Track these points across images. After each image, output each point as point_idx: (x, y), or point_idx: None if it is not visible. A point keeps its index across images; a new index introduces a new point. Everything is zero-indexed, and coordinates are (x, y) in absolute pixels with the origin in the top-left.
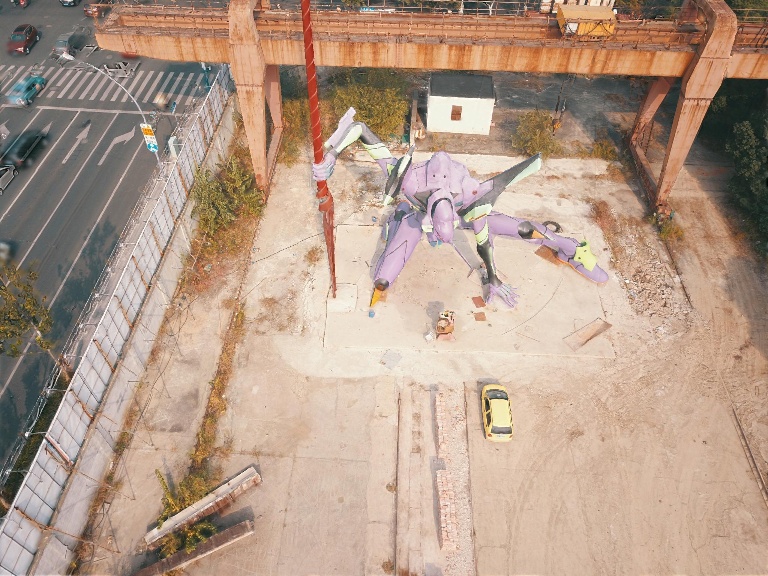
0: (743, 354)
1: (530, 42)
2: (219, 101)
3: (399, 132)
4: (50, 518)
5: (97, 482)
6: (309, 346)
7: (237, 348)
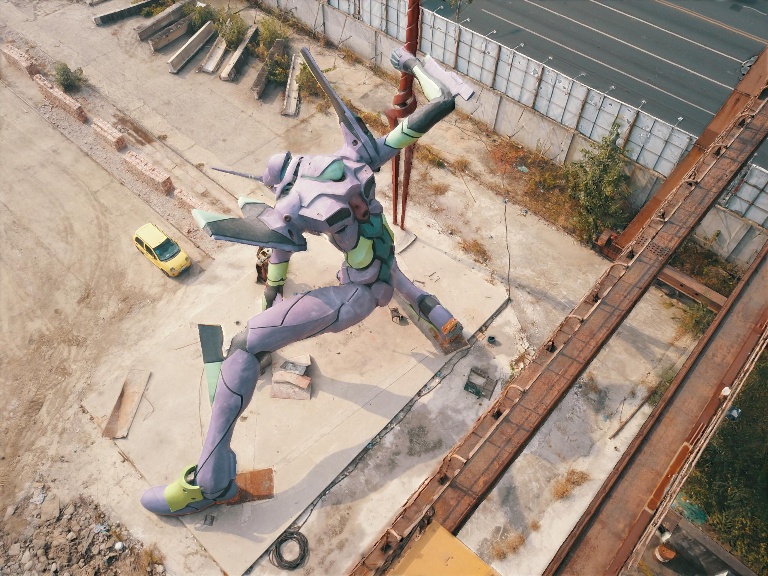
0: None
1: (479, 461)
2: None
3: None
4: (334, 6)
5: None
6: None
7: None
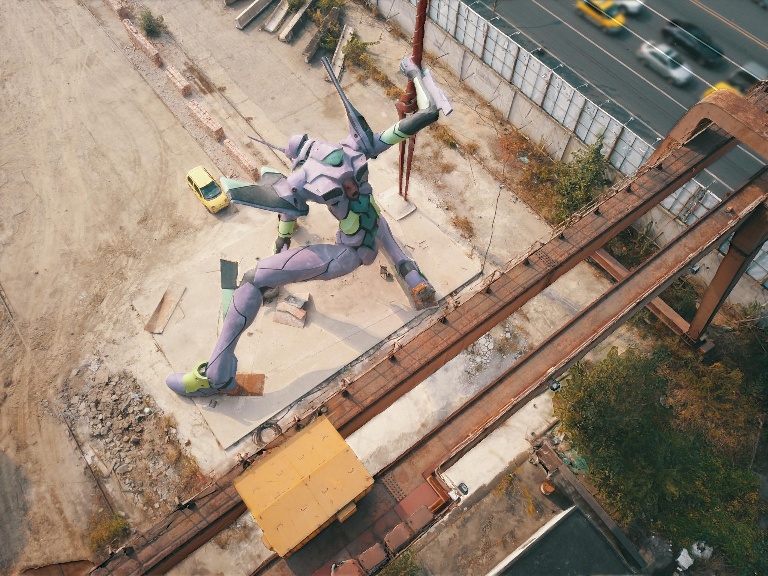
0: (3, 392)
1: (371, 387)
2: (764, 266)
3: (587, 482)
4: None
5: (391, 8)
6: (382, 159)
7: (426, 127)
